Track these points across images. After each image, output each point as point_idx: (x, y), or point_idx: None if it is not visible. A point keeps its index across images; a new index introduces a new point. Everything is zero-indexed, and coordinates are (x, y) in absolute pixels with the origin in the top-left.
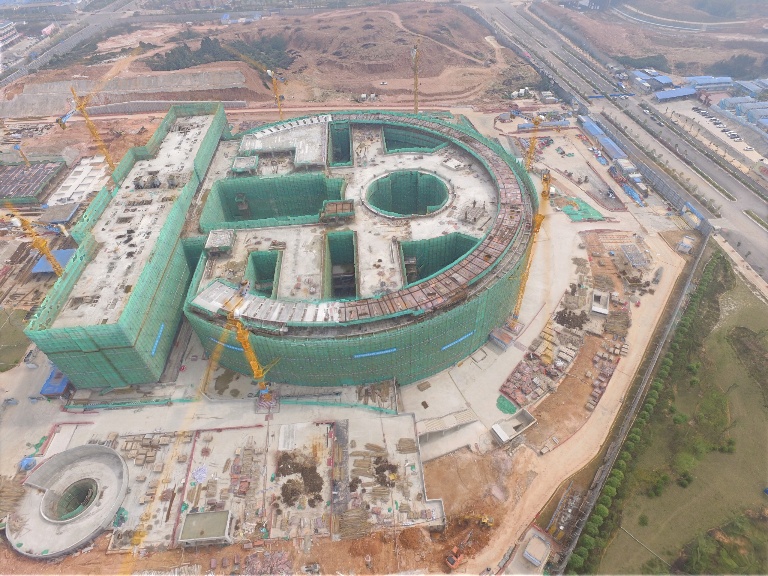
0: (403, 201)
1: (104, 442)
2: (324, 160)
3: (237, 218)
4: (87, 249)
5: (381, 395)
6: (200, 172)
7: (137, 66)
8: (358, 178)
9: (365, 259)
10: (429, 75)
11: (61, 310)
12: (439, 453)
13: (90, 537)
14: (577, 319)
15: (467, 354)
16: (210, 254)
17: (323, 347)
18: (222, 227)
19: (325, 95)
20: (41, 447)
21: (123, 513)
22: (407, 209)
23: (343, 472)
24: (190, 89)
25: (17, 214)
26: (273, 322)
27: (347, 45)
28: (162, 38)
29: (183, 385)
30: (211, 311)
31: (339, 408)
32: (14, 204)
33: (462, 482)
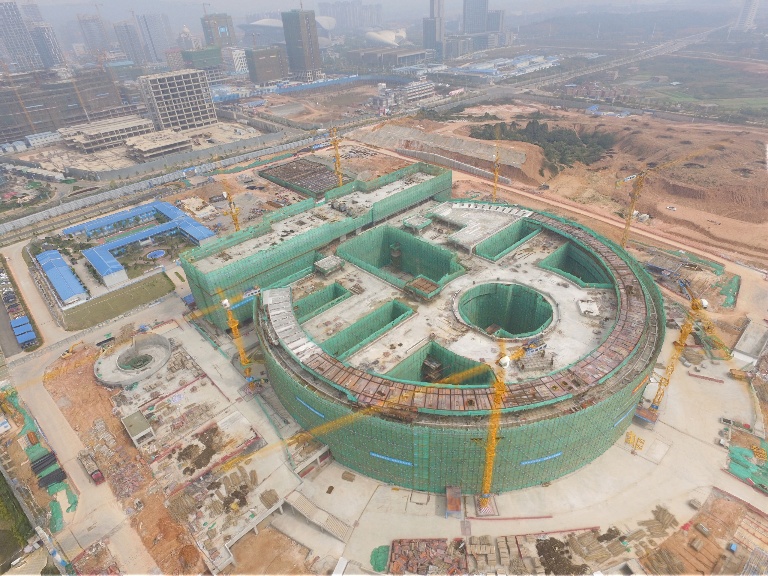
0: (524, 319)
1: (173, 344)
2: (471, 245)
3: (391, 261)
4: (258, 229)
5: (305, 449)
6: (377, 214)
7: (463, 130)
8: (484, 274)
9: (393, 336)
10: (745, 218)
11: (212, 255)
12: (289, 532)
13: (113, 384)
14: (564, 565)
15: (410, 486)
16: (316, 270)
17: (280, 372)
18: (346, 257)
19: (594, 198)
20: (157, 325)
21: (135, 386)
22: (526, 330)
23: (221, 472)
24: (478, 157)
25: (297, 199)
26: (275, 333)
27: (670, 159)
28: (516, 114)
29: (234, 344)
30: (263, 303)
31: (274, 432)
32: (306, 193)
33: (267, 567)
